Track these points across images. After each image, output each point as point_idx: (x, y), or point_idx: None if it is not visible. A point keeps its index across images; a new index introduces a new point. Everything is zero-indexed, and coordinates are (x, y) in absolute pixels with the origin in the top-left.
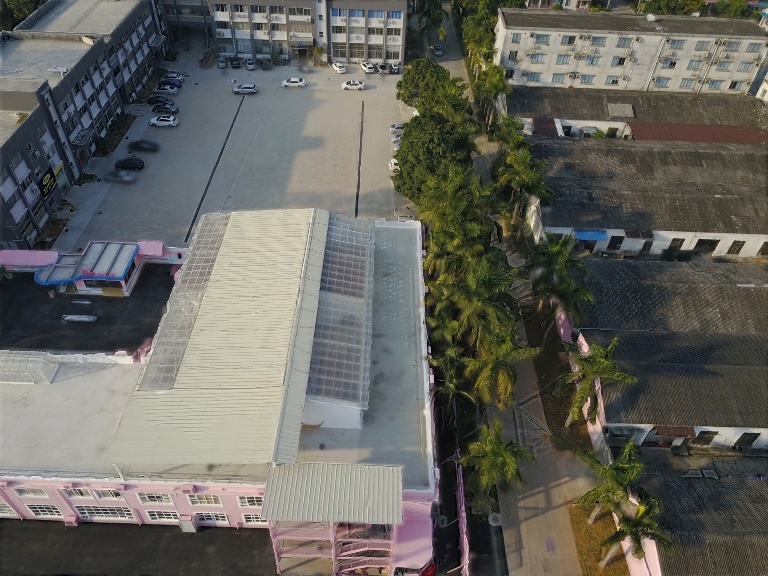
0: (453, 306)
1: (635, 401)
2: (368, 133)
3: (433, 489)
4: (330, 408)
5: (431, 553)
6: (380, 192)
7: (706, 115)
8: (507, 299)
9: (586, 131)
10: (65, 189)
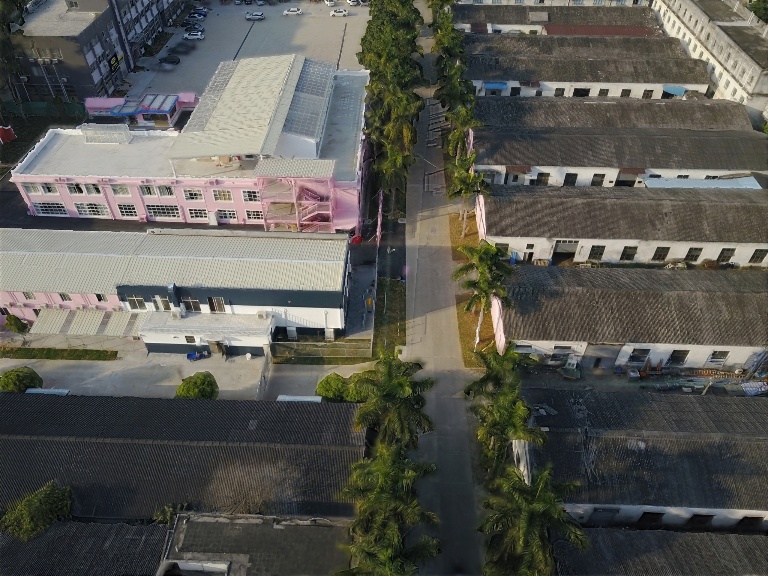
0: (381, 101)
1: (494, 153)
2: (348, 42)
3: (356, 181)
4: (297, 142)
5: (357, 223)
6: None
7: (605, 19)
8: (416, 98)
9: None
10: (124, 74)
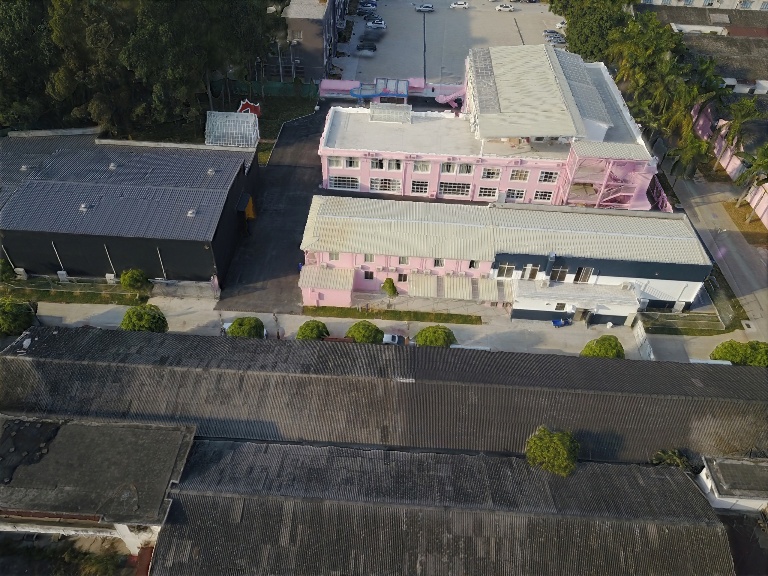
0: (646, 92)
1: (762, 145)
2: (526, 36)
3: (655, 165)
4: (591, 127)
5: None
6: None
7: None
8: None
9: None
10: None
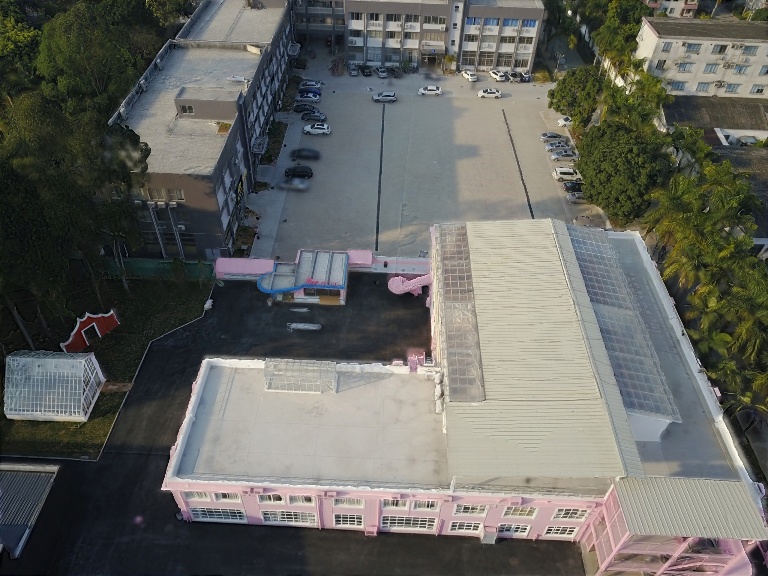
0: (720, 318)
1: None
2: (519, 141)
3: None
4: (641, 421)
5: (751, 568)
6: (551, 201)
7: None
8: None
9: (745, 140)
10: (245, 197)
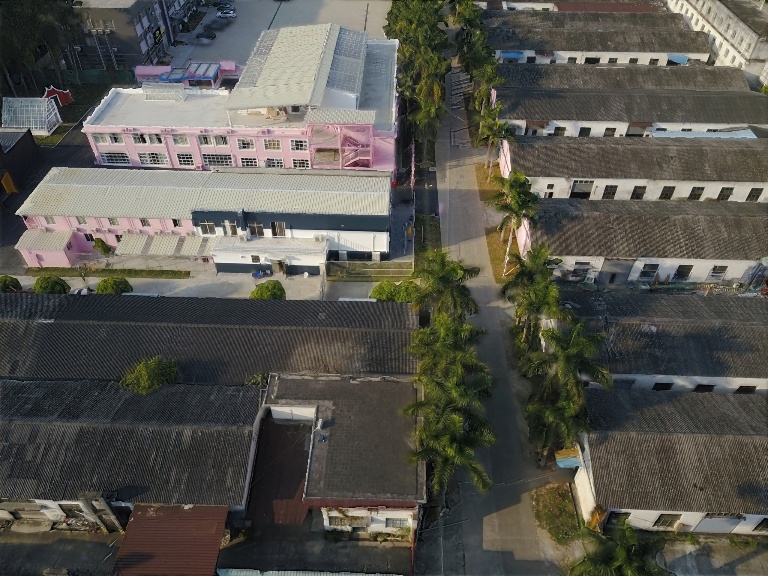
0: (412, 63)
1: (516, 109)
2: (371, 20)
3: (394, 130)
4: (339, 97)
5: None
6: None
7: None
8: None
9: None
10: (166, 47)
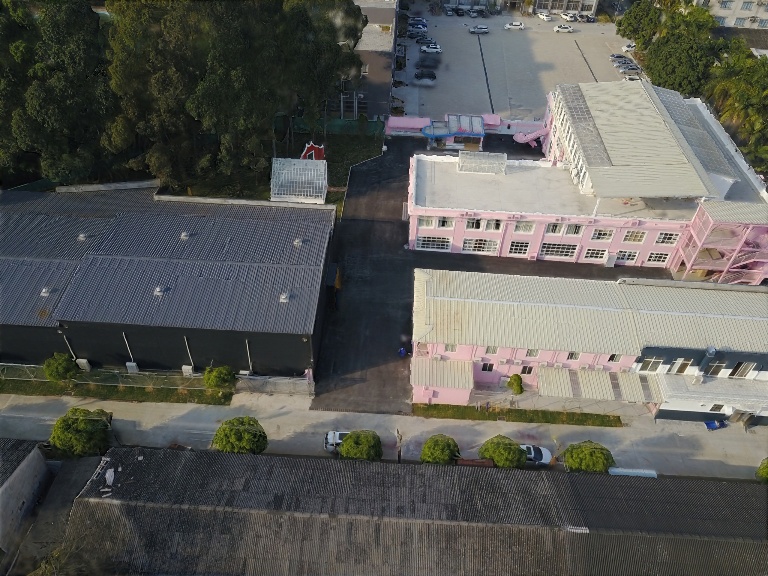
0: (763, 137)
1: None
2: (591, 61)
3: None
4: (714, 181)
5: None
6: None
7: None
8: None
9: None
10: None
